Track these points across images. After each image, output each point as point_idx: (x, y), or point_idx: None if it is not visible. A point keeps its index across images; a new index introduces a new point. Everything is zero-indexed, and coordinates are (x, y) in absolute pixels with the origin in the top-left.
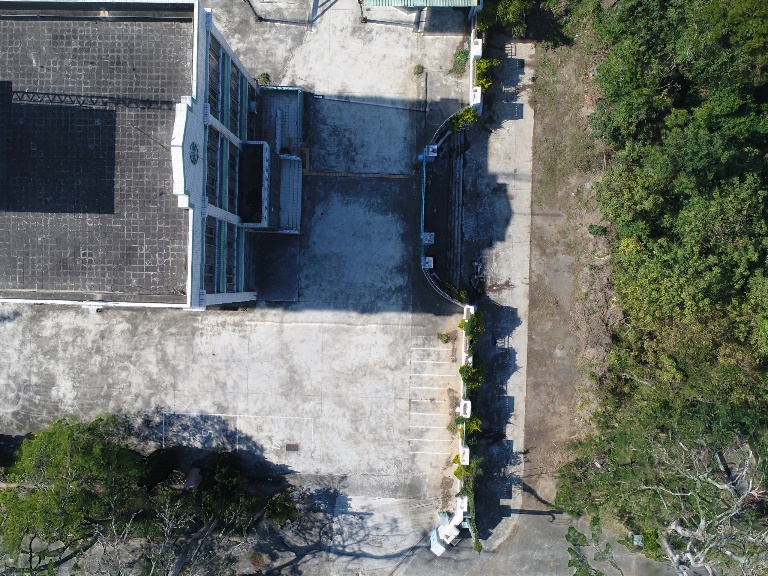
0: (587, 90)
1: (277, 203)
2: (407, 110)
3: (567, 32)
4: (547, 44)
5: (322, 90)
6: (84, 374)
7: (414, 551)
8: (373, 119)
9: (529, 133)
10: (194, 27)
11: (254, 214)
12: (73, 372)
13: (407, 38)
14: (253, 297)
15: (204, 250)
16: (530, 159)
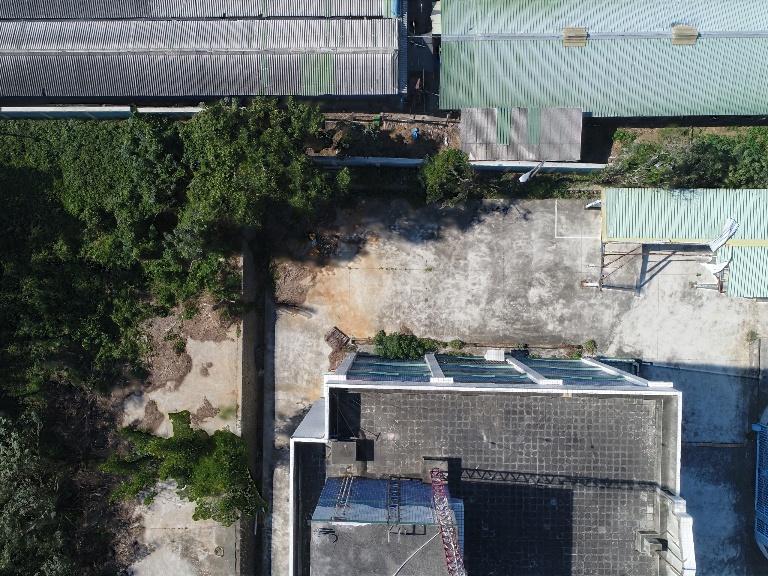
0: None
1: None
2: (739, 377)
3: None
4: None
5: (650, 357)
6: None
7: None
8: (704, 387)
9: None
10: (678, 421)
11: None
12: None
13: (739, 304)
14: None
15: None
16: None
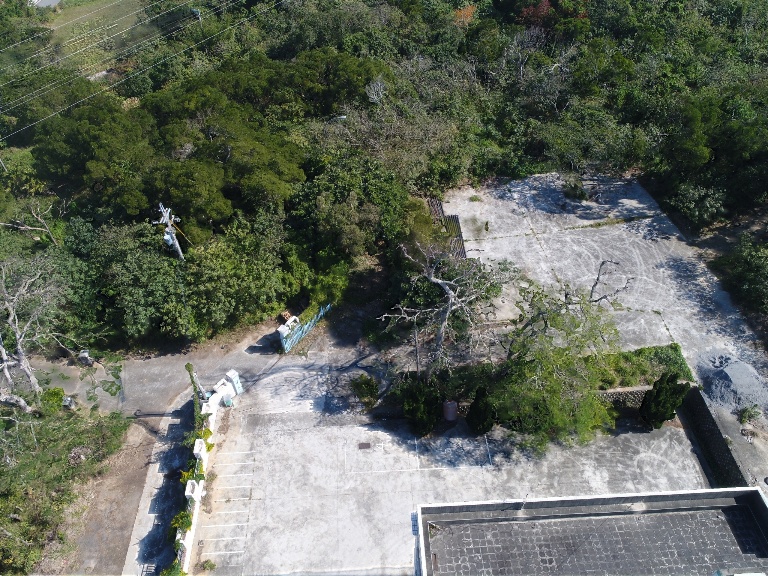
0: None
1: None
2: None
3: None
4: None
5: None
6: None
7: (259, 378)
8: None
9: None
10: None
11: None
12: None
13: None
14: None
15: None
16: None
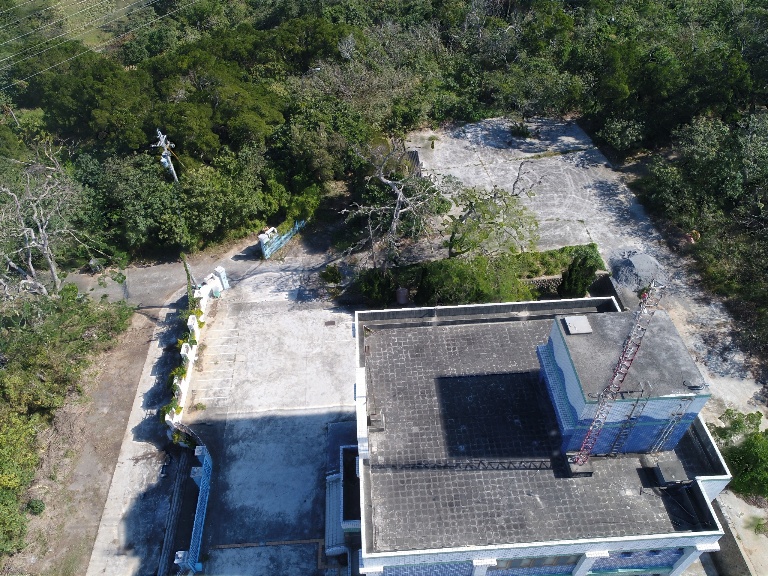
0: None
1: None
2: None
3: None
4: None
5: None
6: None
7: (243, 278)
8: None
9: None
10: None
11: (352, 460)
12: None
13: None
14: None
15: None
16: None
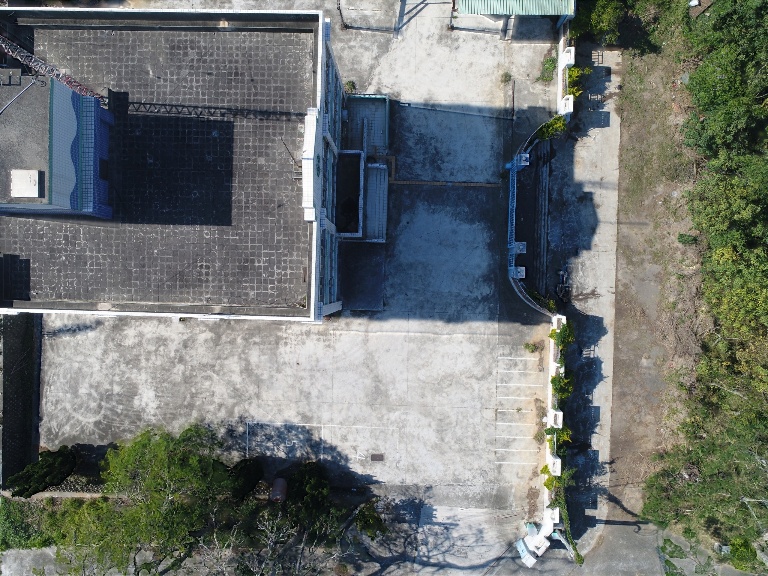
0: (674, 98)
1: (365, 212)
2: (494, 118)
3: (655, 40)
4: (634, 52)
5: (408, 98)
6: (167, 383)
7: (499, 562)
8: (460, 127)
9: (615, 141)
10: (318, 38)
11: (350, 224)
12: (156, 381)
13: (494, 46)
14: (340, 306)
15: (320, 262)
16: (616, 167)
